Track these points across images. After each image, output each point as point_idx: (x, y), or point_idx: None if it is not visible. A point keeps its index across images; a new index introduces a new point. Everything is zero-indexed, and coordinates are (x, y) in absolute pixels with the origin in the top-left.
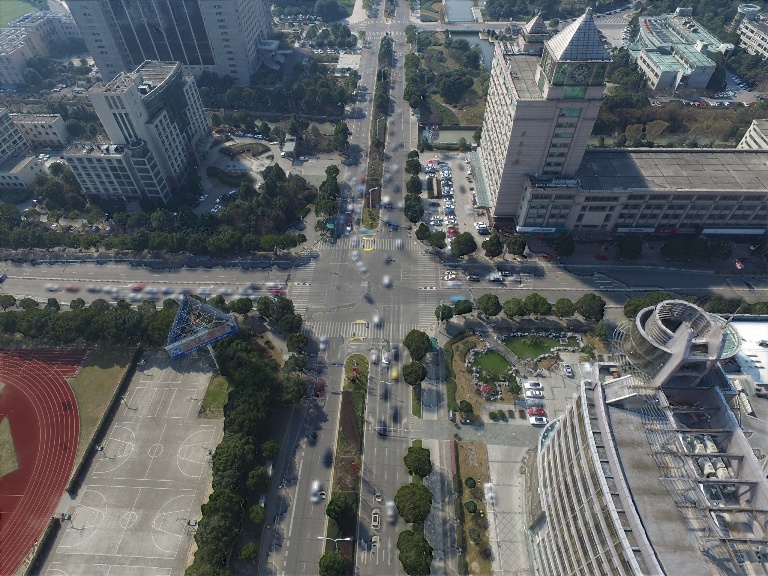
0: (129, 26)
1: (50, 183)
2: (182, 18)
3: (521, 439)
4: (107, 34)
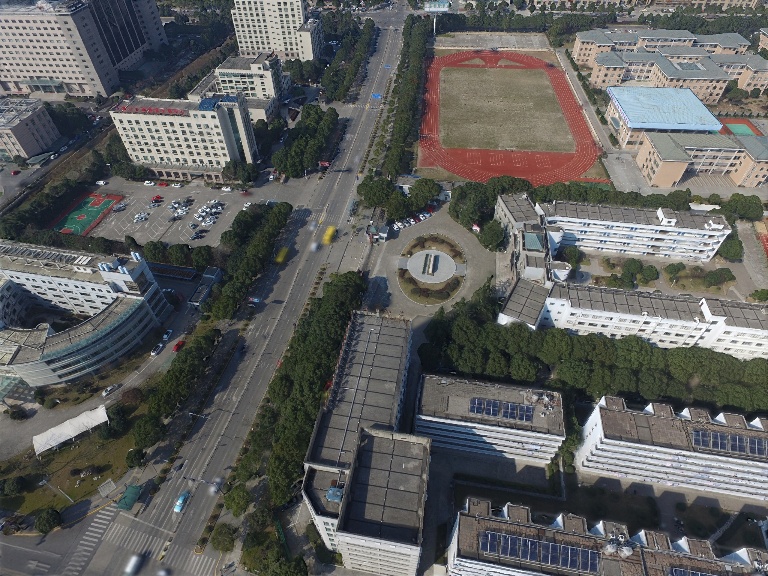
0: (99, 30)
1: (309, 61)
2: (122, 7)
3: (457, 4)
4: (99, 40)
